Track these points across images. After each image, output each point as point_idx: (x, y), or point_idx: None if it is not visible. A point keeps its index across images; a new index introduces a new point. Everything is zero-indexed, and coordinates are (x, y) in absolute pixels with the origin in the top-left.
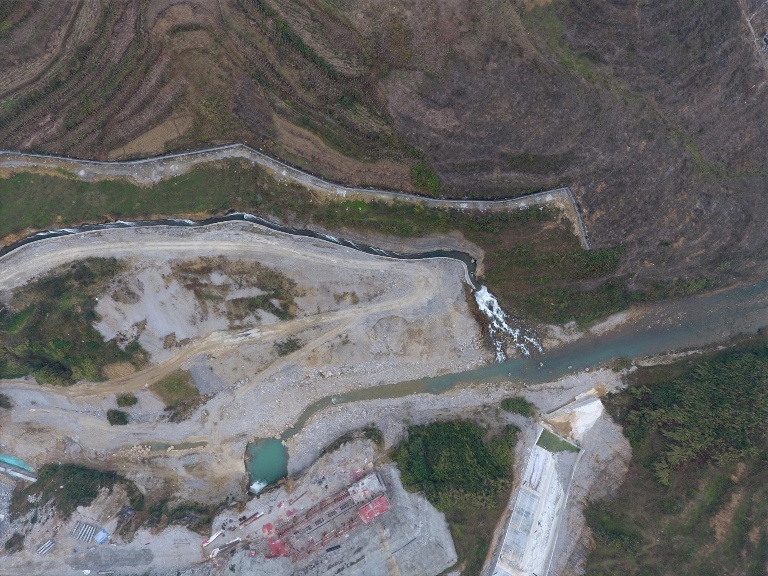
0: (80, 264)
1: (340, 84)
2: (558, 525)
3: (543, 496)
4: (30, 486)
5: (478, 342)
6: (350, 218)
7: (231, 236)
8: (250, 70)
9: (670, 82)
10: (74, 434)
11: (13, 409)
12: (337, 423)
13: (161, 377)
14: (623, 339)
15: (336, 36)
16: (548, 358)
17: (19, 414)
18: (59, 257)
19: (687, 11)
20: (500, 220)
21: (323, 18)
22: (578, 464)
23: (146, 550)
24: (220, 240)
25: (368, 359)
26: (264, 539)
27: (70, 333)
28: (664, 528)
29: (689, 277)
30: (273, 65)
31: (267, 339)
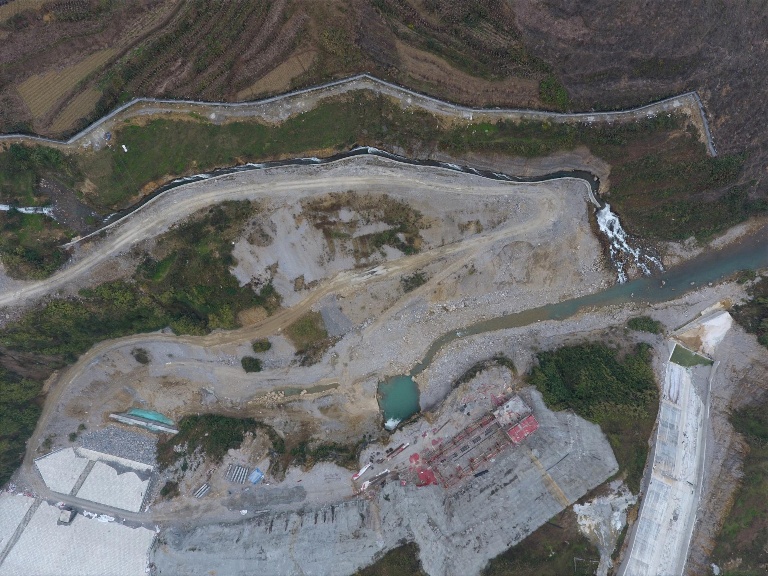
0: (217, 208)
1: (465, 2)
2: (704, 435)
3: (684, 409)
4: (173, 437)
5: (600, 264)
6: (477, 141)
7: (358, 171)
8: None
9: None
10: (209, 385)
11: (150, 364)
12: (465, 355)
13: (293, 320)
14: (744, 251)
15: None
16: (669, 276)
17: (156, 368)
18: (196, 203)
19: None
20: (628, 131)
21: None
22: (714, 376)
23: (299, 487)
24: (348, 175)
25: (491, 290)
26: (412, 469)
27: (210, 279)
28: None
29: None
30: None
31: (393, 275)
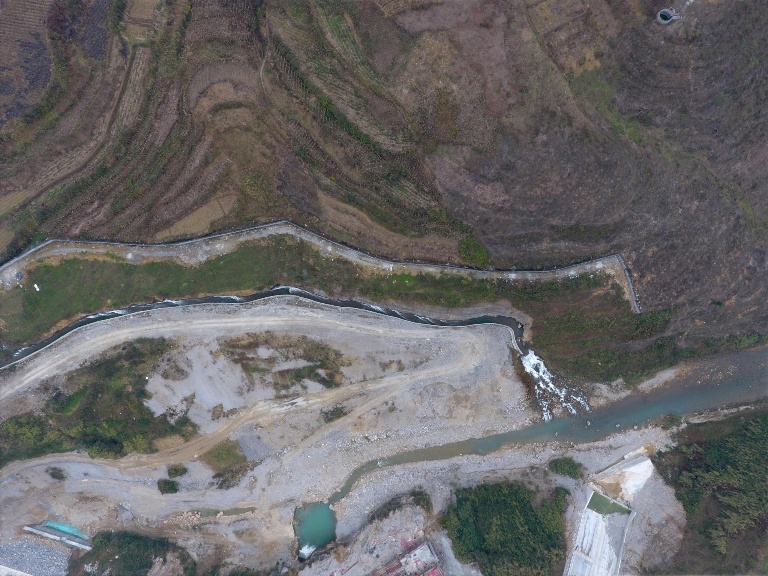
0: (130, 346)
1: (386, 161)
2: None
3: (595, 561)
4: (85, 555)
5: (524, 403)
6: (397, 291)
7: (277, 311)
8: (294, 147)
9: (723, 141)
10: (125, 502)
11: (66, 480)
12: (384, 487)
13: (210, 447)
14: (672, 395)
15: (381, 113)
16: (595, 416)
17: (72, 485)
18: (109, 339)
19: (742, 70)
20: (549, 289)
21: (367, 95)
22: (630, 527)
23: None
24: (266, 315)
25: (413, 422)
26: None
27: (122, 412)
28: None
29: (741, 333)
30: (317, 143)
31: (313, 407)
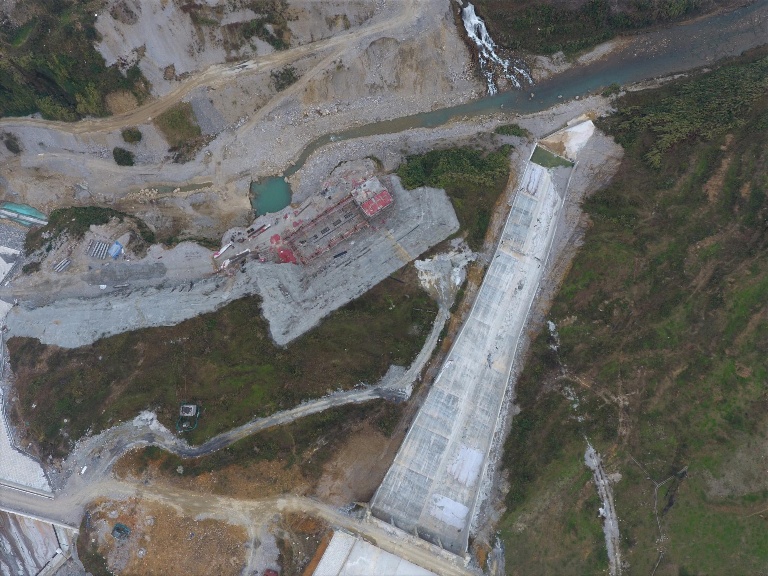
0: None
1: None
2: (556, 221)
3: (541, 200)
4: None
5: (469, 72)
6: None
7: None
8: None
9: None
10: (82, 180)
11: (22, 154)
12: (337, 158)
13: (163, 110)
14: (610, 68)
15: None
16: (538, 89)
17: (28, 159)
18: None
19: None
20: None
21: None
22: (573, 174)
23: (159, 264)
24: None
25: (363, 94)
26: (272, 249)
27: (72, 50)
28: (658, 201)
29: None
30: None
31: (264, 69)
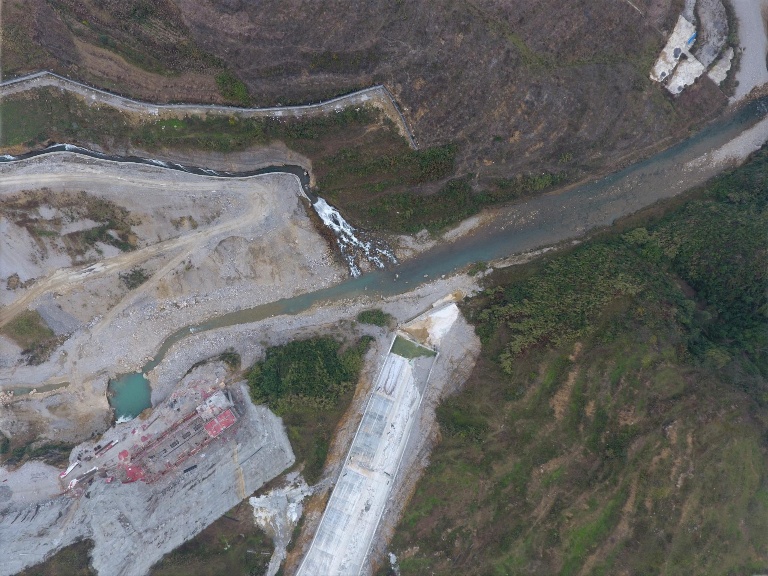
0: None
1: None
2: (411, 425)
3: (398, 400)
4: None
5: (329, 258)
6: (167, 137)
7: (53, 168)
8: None
9: None
10: None
11: None
12: (196, 351)
13: (9, 319)
14: (477, 243)
15: None
16: (403, 269)
17: None
18: None
19: None
20: (318, 125)
21: None
22: (433, 367)
23: (4, 487)
24: (42, 173)
25: (221, 285)
26: (121, 466)
27: None
28: (507, 414)
29: (533, 173)
30: None
31: (111, 272)
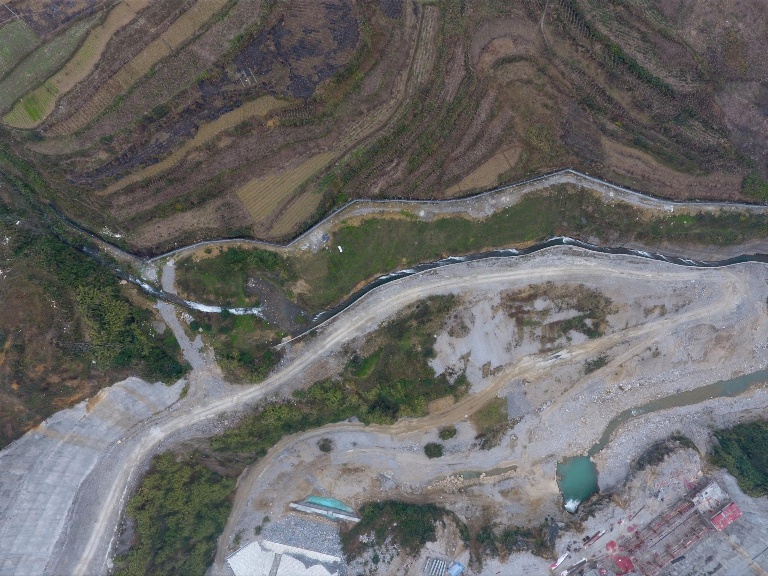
0: (423, 303)
1: (676, 102)
2: None
3: None
4: (357, 526)
5: None
6: (676, 232)
7: (554, 261)
8: (577, 96)
9: None
10: (388, 471)
11: (331, 452)
12: (642, 435)
13: (479, 406)
14: None
15: (670, 55)
16: None
17: (338, 456)
18: (403, 299)
19: None
20: None
21: (656, 38)
22: None
23: None
24: (545, 266)
25: (666, 369)
26: (609, 557)
27: (411, 372)
28: None
29: None
30: (604, 89)
31: (578, 359)
